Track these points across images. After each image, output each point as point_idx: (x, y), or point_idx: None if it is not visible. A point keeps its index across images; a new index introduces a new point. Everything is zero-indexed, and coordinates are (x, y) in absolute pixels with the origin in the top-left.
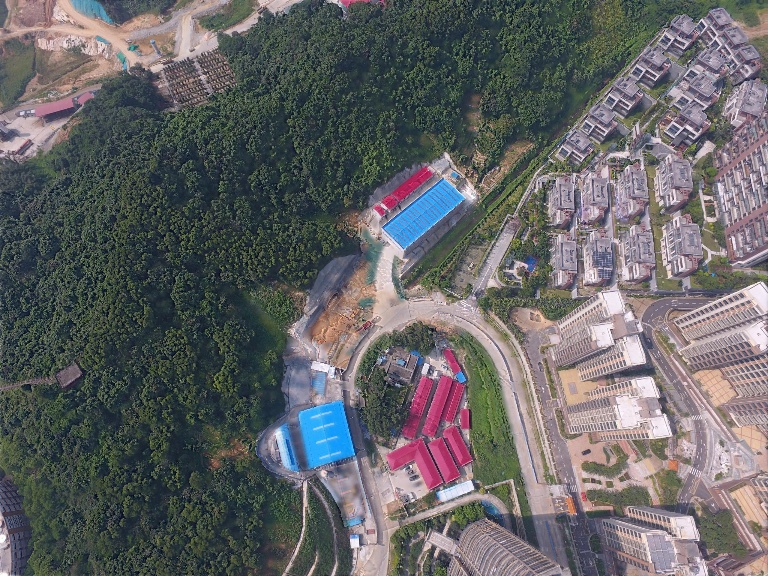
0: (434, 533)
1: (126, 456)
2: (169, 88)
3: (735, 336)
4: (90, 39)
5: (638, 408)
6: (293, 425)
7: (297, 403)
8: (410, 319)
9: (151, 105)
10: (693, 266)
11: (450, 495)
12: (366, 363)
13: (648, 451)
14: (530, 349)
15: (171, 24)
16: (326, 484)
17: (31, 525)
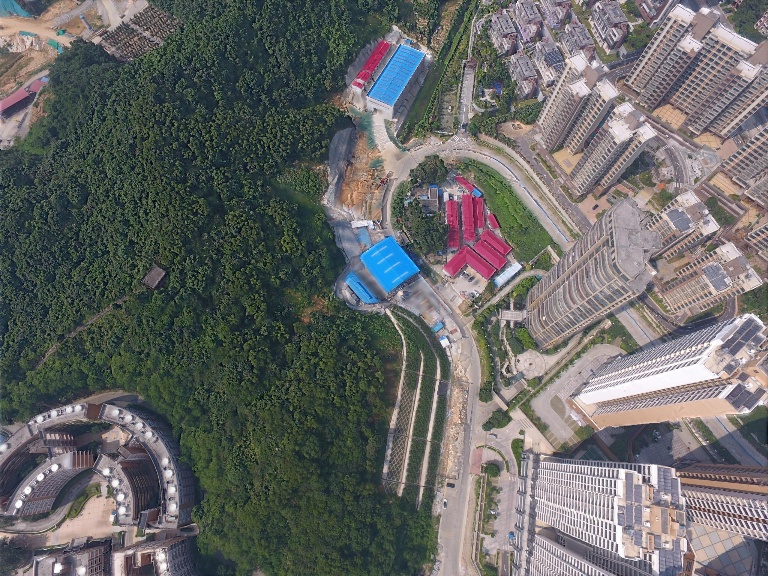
0: (504, 312)
1: (232, 327)
2: (117, 51)
3: (674, 52)
4: (14, 36)
5: (626, 125)
6: (358, 270)
7: (353, 255)
8: (417, 165)
9: None
10: (624, 31)
11: (505, 277)
12: (396, 209)
13: (640, 185)
14: (523, 151)
15: (89, 2)
16: (405, 302)
17: (169, 418)
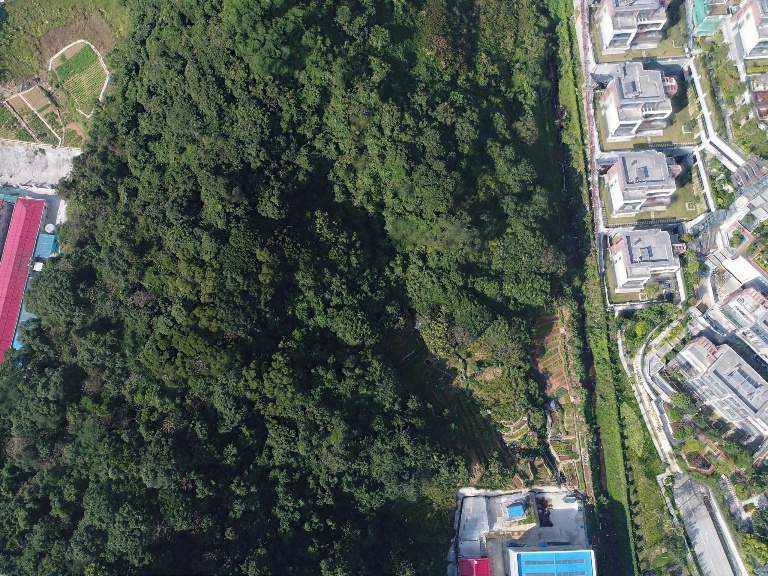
0: None
1: None
2: None
3: None
4: None
5: None
6: None
7: None
8: None
9: None
10: None
11: None
12: None
13: None
14: None
15: None
16: None
17: None
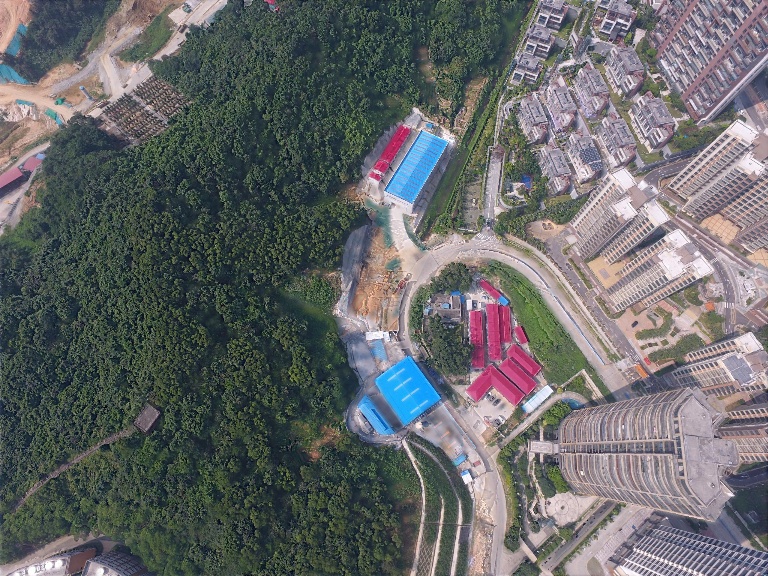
0: (533, 442)
1: (232, 475)
2: (118, 128)
3: (732, 172)
4: (10, 105)
5: (678, 258)
6: (372, 394)
7: (367, 374)
8: (438, 266)
9: (110, 146)
10: (670, 133)
11: (535, 404)
12: (414, 318)
13: (685, 303)
14: (554, 255)
15: (91, 68)
16: (424, 434)
17: None
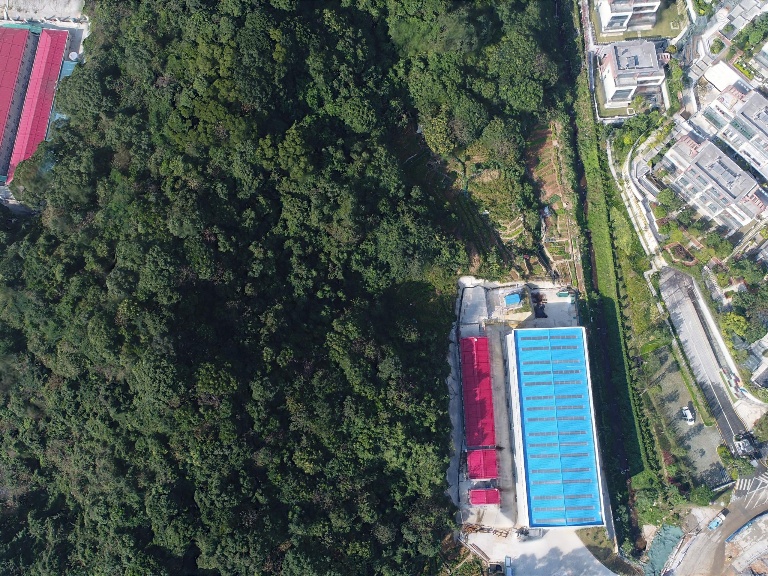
0: None
1: None
2: None
3: None
4: None
5: None
6: None
7: None
8: None
9: None
10: None
11: None
12: None
13: None
14: None
15: None
16: None
17: None
